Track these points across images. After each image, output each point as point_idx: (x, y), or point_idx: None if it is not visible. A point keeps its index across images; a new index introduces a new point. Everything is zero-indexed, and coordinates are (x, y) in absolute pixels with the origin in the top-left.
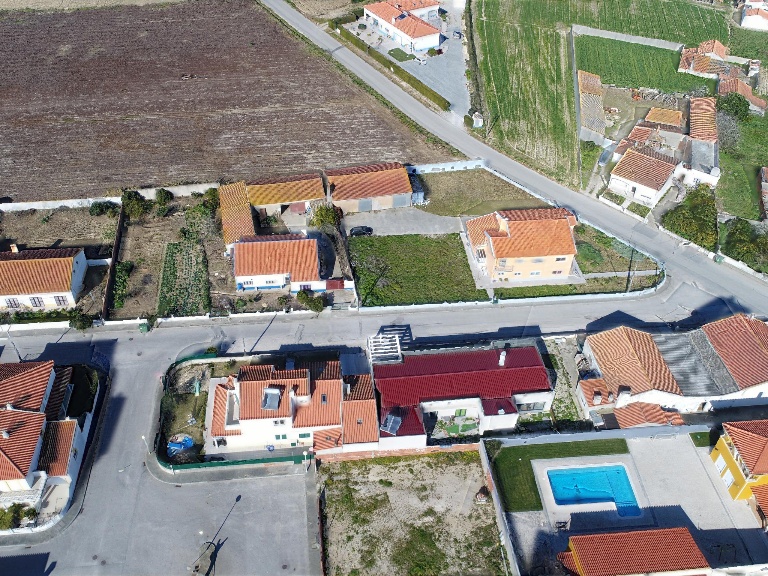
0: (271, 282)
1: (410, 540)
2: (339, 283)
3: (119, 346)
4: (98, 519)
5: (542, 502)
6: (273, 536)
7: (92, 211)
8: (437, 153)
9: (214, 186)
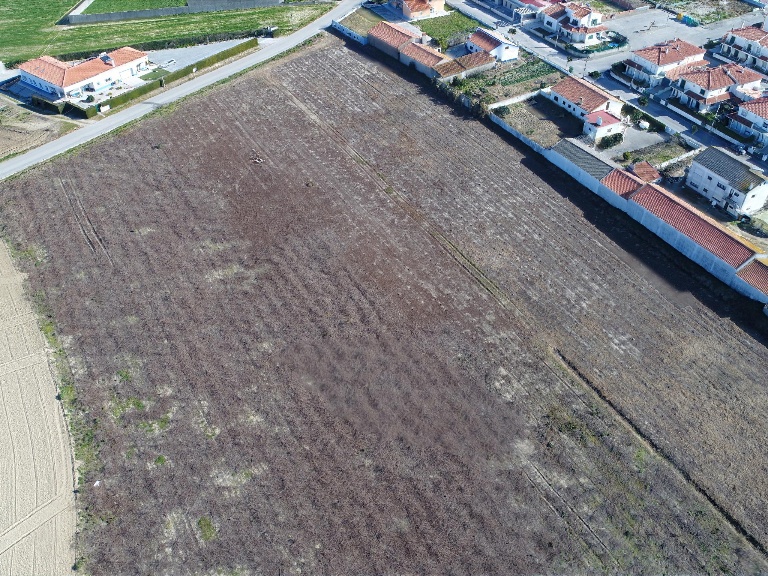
0: None
1: (593, 6)
2: None
3: None
4: None
5: None
6: None
7: None
8: (324, 40)
9: None
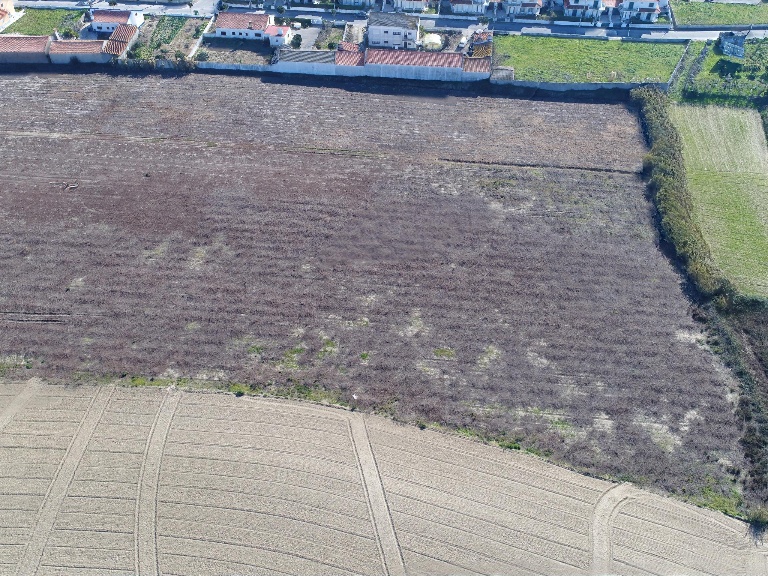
0: None
1: None
2: None
3: None
4: None
5: None
6: None
7: None
8: None
9: None
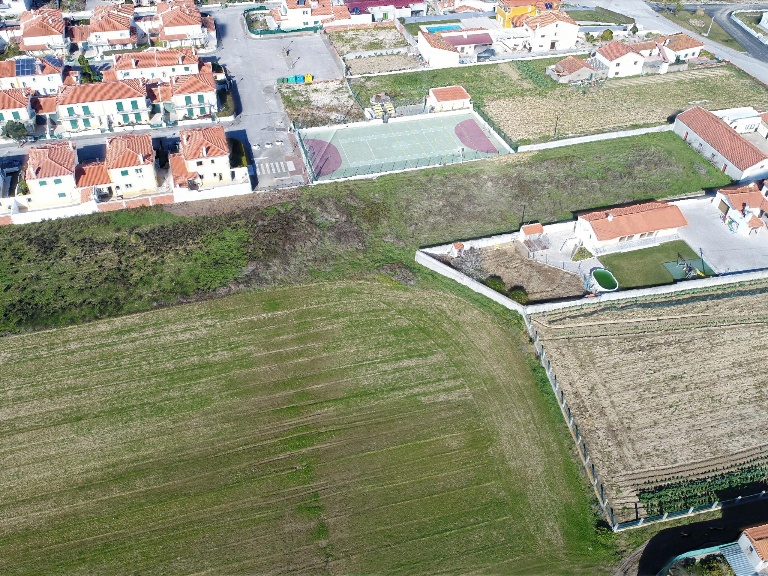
0: None
1: (370, 44)
2: None
3: (214, 12)
4: (232, 49)
5: None
6: (311, 48)
7: None
8: None
9: None
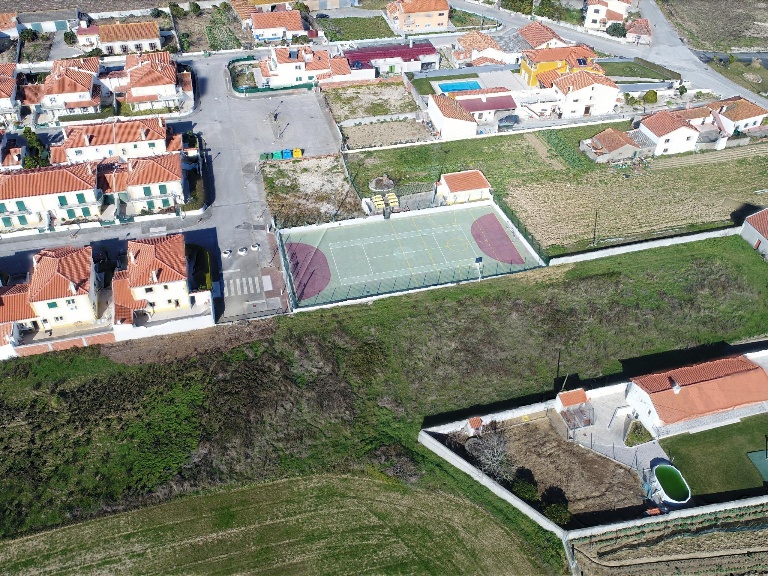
0: (275, 35)
1: (372, 106)
2: (315, 33)
3: (195, 62)
4: (212, 111)
5: (436, 92)
6: (304, 110)
7: (153, 13)
8: None
9: (225, 1)
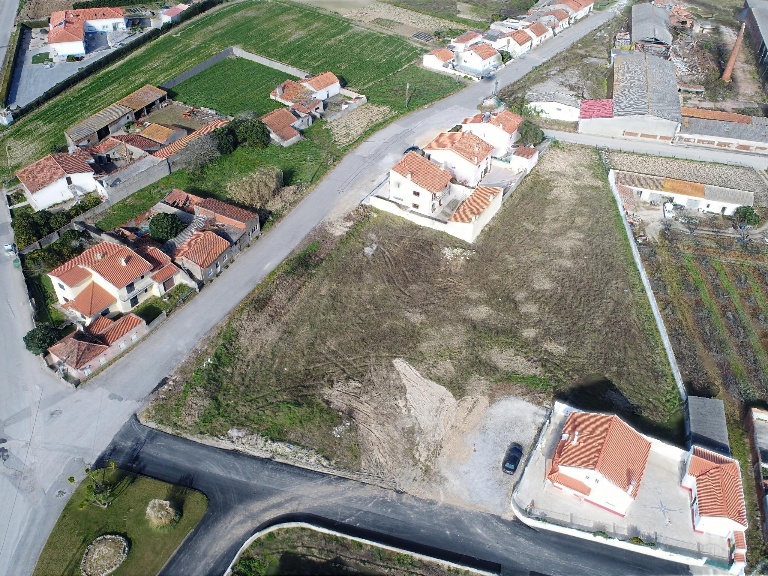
0: None
1: None
2: None
3: None
4: None
5: None
6: None
7: None
8: None
9: None
